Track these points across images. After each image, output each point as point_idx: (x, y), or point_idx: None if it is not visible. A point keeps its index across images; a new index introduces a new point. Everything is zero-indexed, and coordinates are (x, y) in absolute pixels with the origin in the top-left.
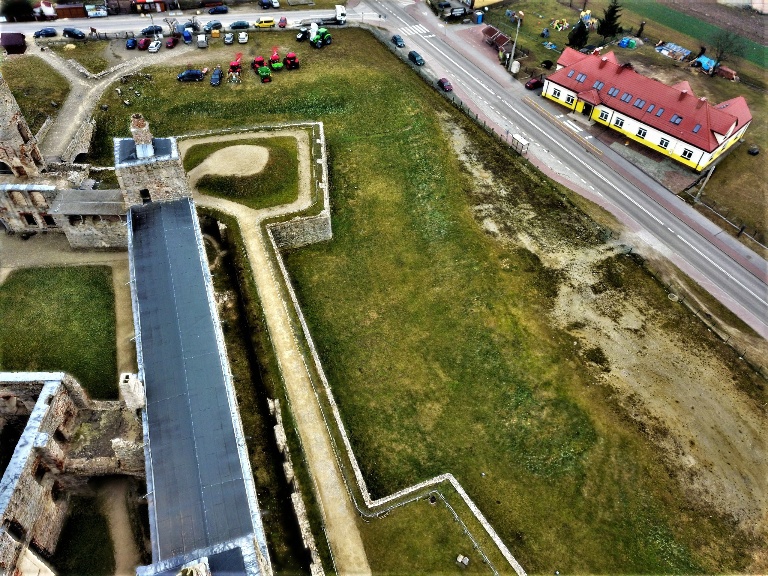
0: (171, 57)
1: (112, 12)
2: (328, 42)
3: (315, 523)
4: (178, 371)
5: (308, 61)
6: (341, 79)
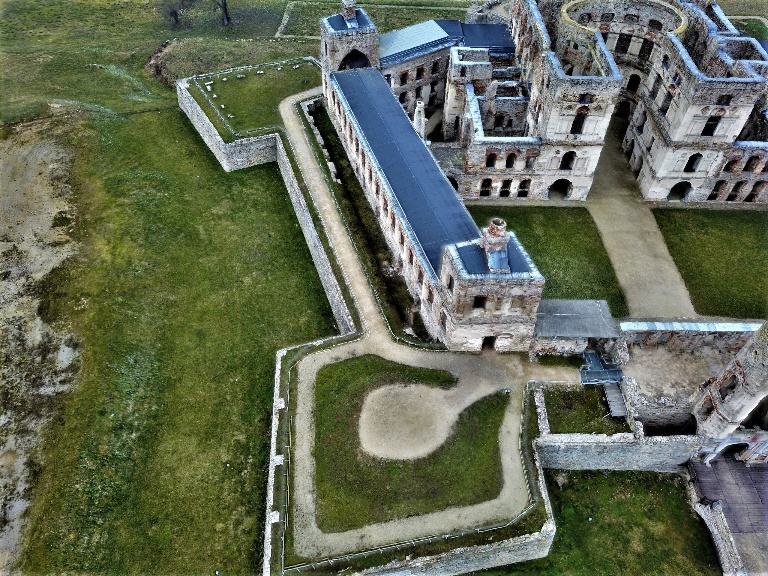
0: None
1: None
2: None
3: (310, 131)
4: (396, 136)
5: None
6: None
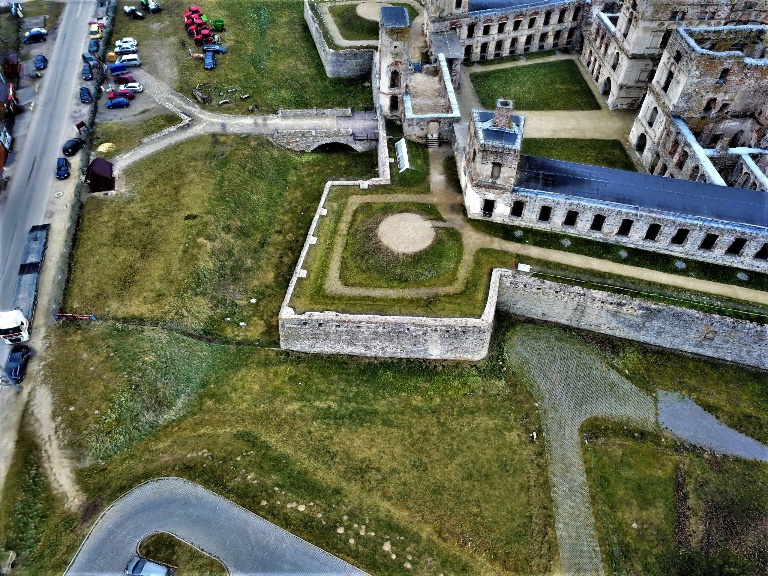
0: (156, 79)
1: None
2: None
3: None
4: None
5: None
6: (224, 1)
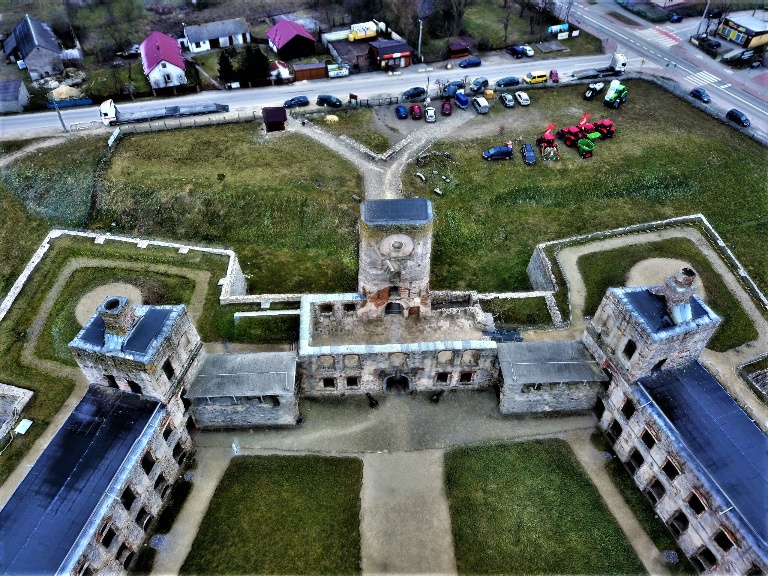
0: (455, 127)
1: (352, 70)
2: (623, 100)
3: None
4: None
5: (615, 126)
6: (669, 149)
